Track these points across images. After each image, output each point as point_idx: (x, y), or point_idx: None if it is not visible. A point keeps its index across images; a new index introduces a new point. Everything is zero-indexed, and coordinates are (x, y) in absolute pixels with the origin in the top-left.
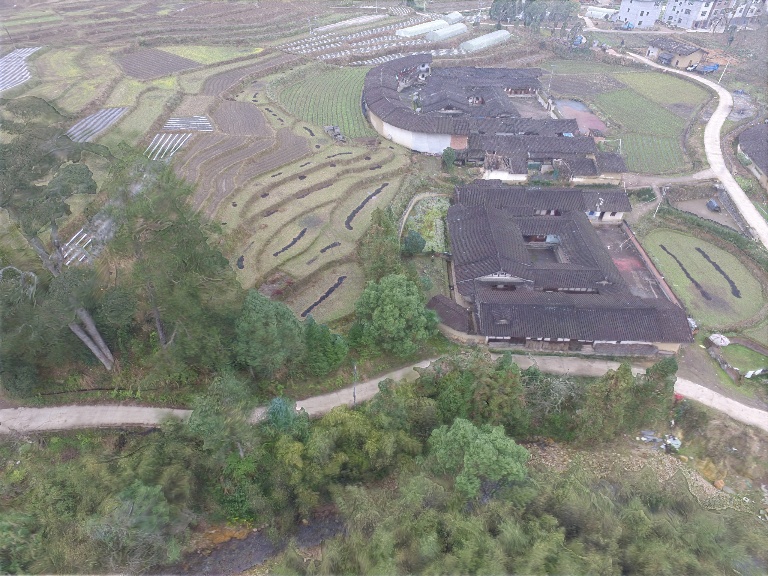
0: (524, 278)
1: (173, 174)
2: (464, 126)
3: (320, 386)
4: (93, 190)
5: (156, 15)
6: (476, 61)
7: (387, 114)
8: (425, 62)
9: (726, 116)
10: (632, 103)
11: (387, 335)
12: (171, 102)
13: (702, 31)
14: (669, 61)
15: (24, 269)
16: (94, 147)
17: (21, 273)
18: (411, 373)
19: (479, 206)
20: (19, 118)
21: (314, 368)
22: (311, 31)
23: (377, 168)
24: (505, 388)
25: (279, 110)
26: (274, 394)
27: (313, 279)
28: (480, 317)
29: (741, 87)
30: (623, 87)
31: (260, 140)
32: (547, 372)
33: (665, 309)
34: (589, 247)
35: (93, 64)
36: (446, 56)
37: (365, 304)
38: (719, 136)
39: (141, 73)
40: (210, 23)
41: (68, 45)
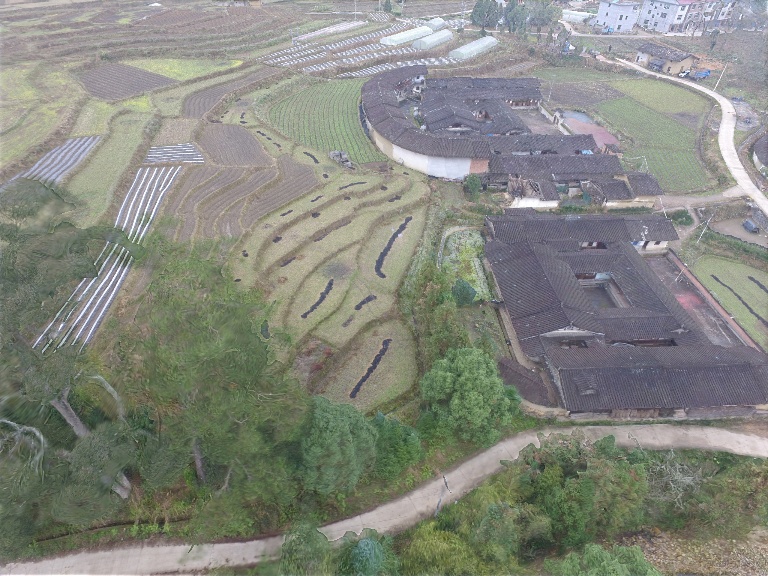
0: (594, 331)
1: (167, 220)
2: (484, 148)
3: (388, 490)
4: (94, 273)
5: (116, 24)
6: (469, 70)
7: (397, 136)
8: (420, 74)
9: (734, 126)
10: (636, 113)
11: (470, 427)
12: (150, 128)
13: (679, 34)
14: (660, 67)
15: (6, 386)
16: (107, 234)
17: (18, 429)
18: (489, 461)
19: (522, 243)
20: (8, 217)
21: (383, 472)
22: (293, 41)
23: (396, 199)
24: (630, 493)
25: (273, 133)
26: (335, 507)
27: (353, 345)
28: (561, 387)
29: (735, 93)
30: (622, 96)
31: (260, 171)
32: (642, 447)
33: (759, 363)
34: (651, 287)
35: (50, 83)
36: (437, 66)
37: (438, 388)
38: (735, 148)
39: (108, 93)
40: (178, 33)
41: (18, 61)
